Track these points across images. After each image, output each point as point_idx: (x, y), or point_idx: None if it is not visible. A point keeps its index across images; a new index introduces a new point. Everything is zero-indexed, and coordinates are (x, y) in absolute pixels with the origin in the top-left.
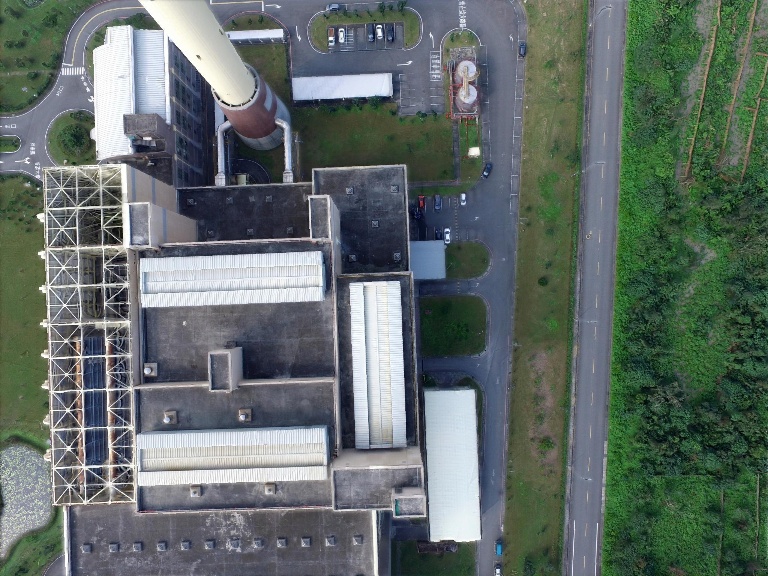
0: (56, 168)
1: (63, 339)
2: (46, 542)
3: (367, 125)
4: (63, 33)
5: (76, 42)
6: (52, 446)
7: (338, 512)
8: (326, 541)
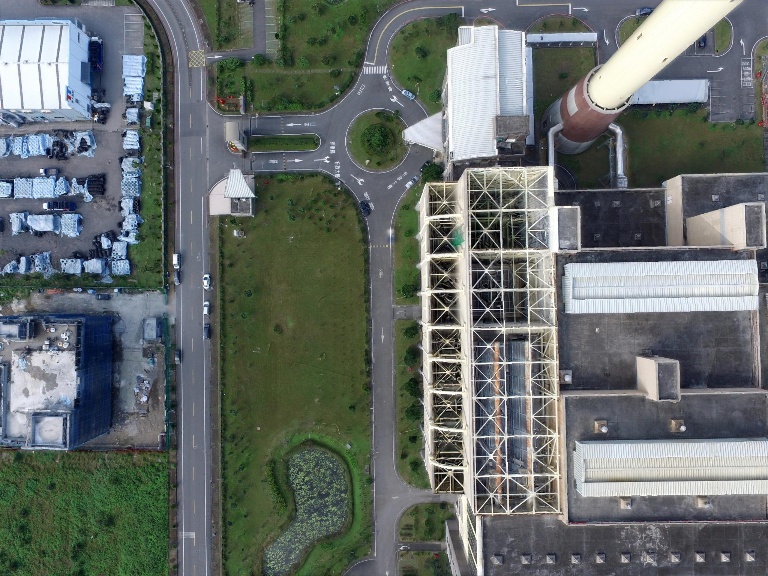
0: (480, 169)
1: (486, 344)
2: (343, 549)
3: (676, 131)
4: (366, 31)
5: (379, 41)
6: (474, 454)
7: (758, 526)
8: (748, 556)
